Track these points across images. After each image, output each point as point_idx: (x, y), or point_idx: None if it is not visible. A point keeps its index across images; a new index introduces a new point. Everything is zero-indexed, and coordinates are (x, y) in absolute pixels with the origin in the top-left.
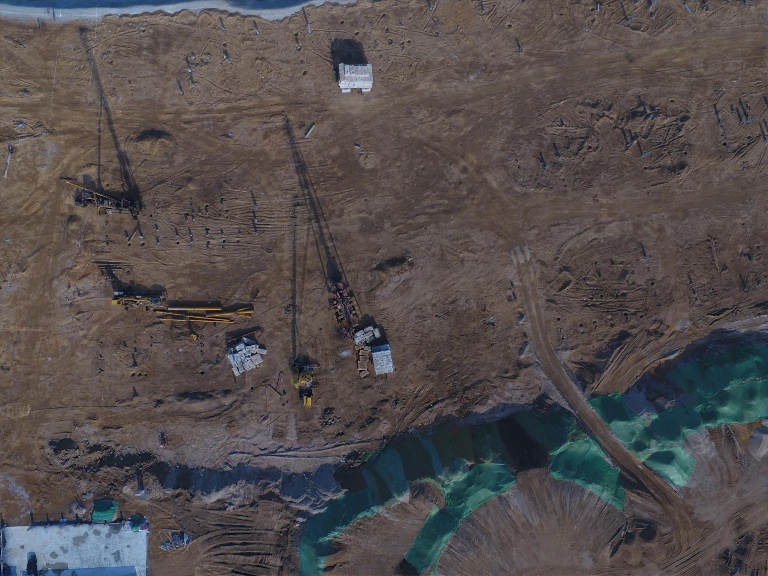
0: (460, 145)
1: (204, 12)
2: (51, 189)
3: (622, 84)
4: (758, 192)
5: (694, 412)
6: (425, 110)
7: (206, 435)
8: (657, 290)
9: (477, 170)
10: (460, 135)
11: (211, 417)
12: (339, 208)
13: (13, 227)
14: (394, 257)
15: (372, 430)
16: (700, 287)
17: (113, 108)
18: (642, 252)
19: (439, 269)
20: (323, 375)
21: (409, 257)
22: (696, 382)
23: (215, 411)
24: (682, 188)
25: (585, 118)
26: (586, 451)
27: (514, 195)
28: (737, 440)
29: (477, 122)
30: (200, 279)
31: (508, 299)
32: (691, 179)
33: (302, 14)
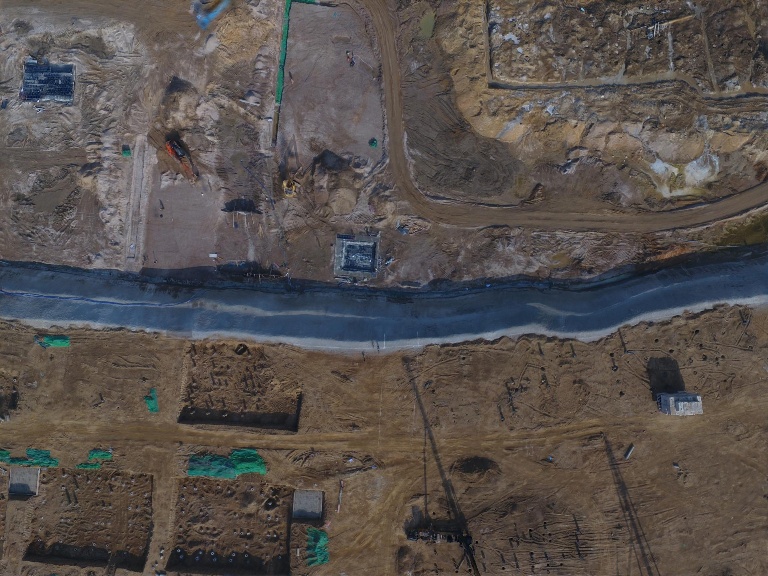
0: None
1: (523, 339)
2: (382, 521)
3: None
4: None
5: None
6: (742, 426)
7: None
8: None
9: None
10: None
11: None
12: (659, 528)
13: (347, 560)
14: (715, 575)
15: None
16: None
17: (437, 437)
18: None
19: None
20: None
21: (731, 575)
22: None
23: None
24: None
25: None
26: None
27: None
28: None
29: None
30: None
31: None
32: None
33: (617, 335)
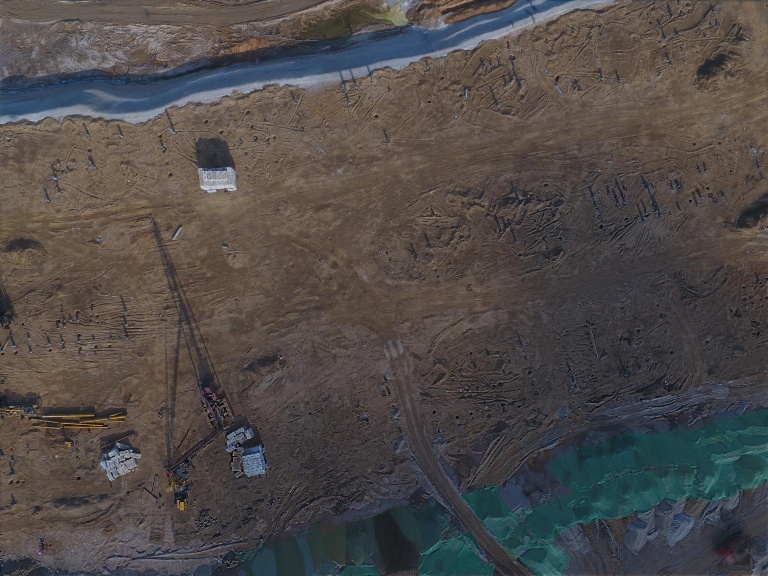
0: (329, 240)
1: (67, 119)
2: None
3: (493, 170)
4: (637, 275)
5: (567, 508)
6: (292, 206)
7: (85, 540)
8: (534, 379)
9: (347, 264)
10: (329, 230)
11: (88, 522)
12: (209, 309)
13: None
14: (266, 356)
15: (249, 530)
16: (579, 374)
17: None
18: (518, 341)
19: (311, 366)
20: (198, 477)
21: (280, 356)
22: (573, 474)
23: (92, 516)
24: (558, 274)
25: (456, 207)
26: (460, 548)
27: (386, 288)
28: (613, 534)
29: (346, 216)
30: (73, 385)
31: (382, 394)
32: (567, 264)
33: (165, 115)
